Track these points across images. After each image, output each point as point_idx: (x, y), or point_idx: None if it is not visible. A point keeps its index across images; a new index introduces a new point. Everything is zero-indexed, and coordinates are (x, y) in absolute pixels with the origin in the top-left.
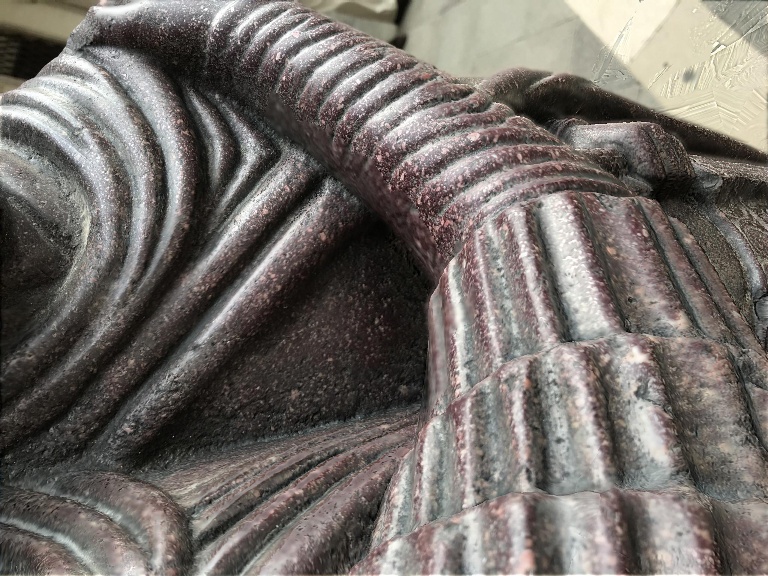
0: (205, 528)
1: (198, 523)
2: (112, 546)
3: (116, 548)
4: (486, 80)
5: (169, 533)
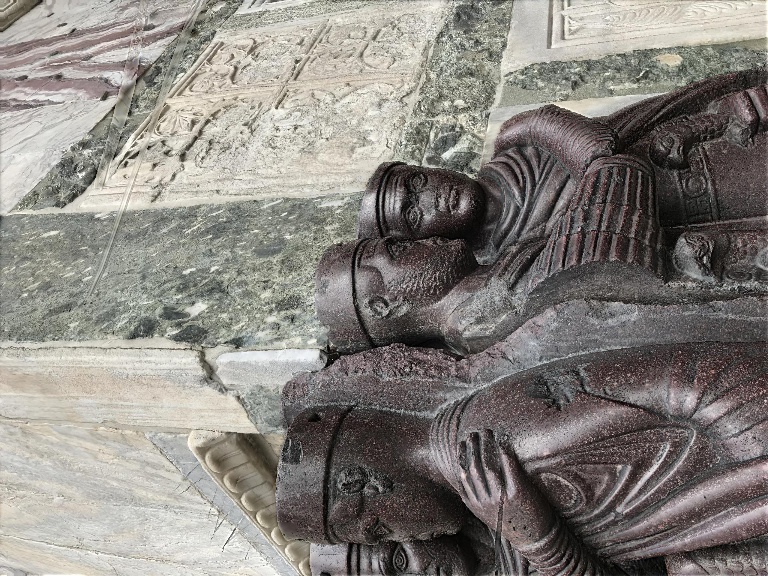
0: (531, 571)
1: (530, 569)
2: (512, 572)
3: (512, 573)
4: (696, 541)
5: (522, 575)
